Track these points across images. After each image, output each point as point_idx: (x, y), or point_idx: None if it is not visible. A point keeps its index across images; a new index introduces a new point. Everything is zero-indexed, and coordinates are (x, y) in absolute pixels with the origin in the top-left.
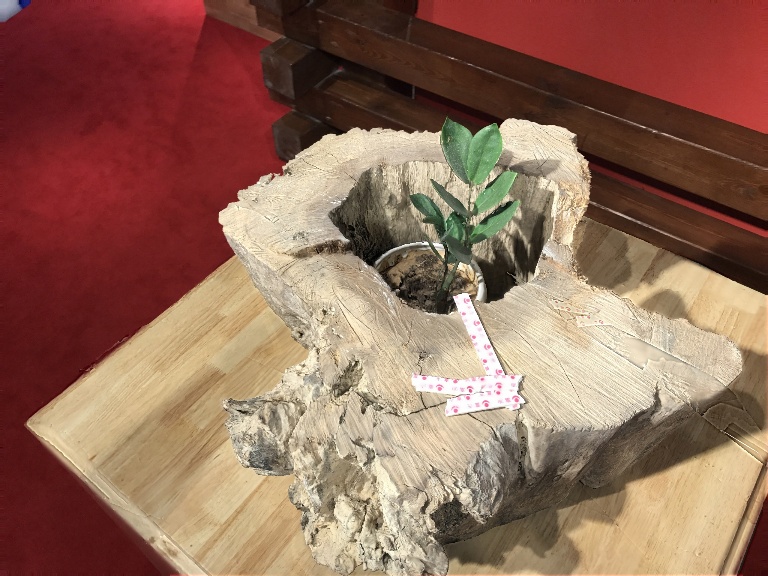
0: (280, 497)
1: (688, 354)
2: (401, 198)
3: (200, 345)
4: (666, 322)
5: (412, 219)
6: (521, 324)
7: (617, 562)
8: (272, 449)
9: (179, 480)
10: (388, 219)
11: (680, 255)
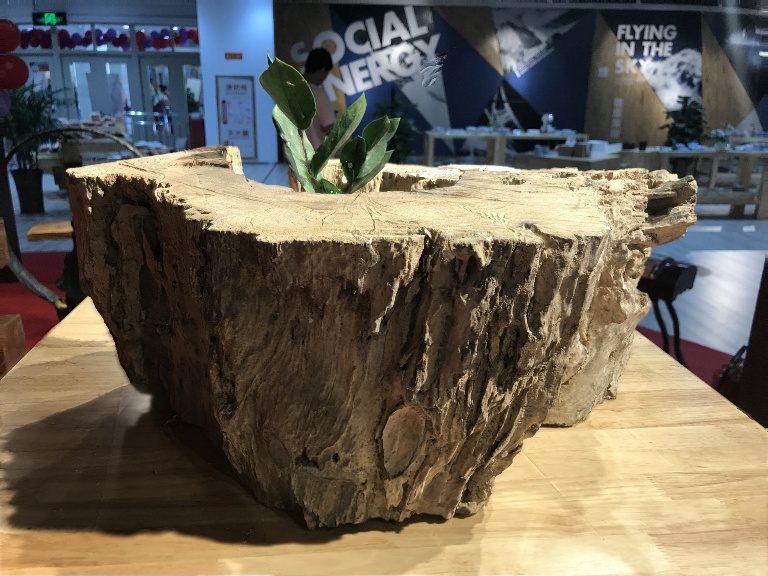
0: (636, 412)
1: None
2: None
3: None
4: None
5: None
6: None
7: None
8: None
9: (766, 474)
10: None
11: (28, 350)
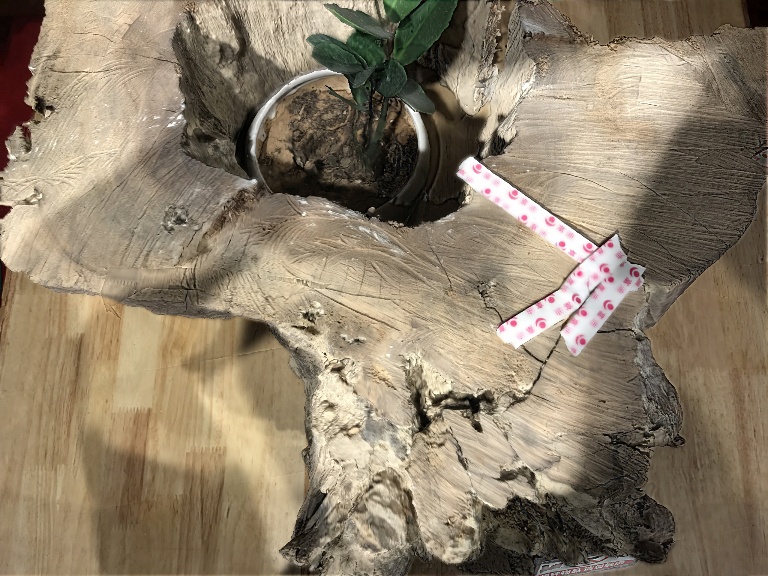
0: None
1: (762, 74)
2: (237, 42)
3: (83, 395)
4: (713, 43)
5: (260, 61)
6: (563, 158)
7: (701, 320)
8: (400, 561)
9: (208, 571)
10: (230, 82)
11: None
